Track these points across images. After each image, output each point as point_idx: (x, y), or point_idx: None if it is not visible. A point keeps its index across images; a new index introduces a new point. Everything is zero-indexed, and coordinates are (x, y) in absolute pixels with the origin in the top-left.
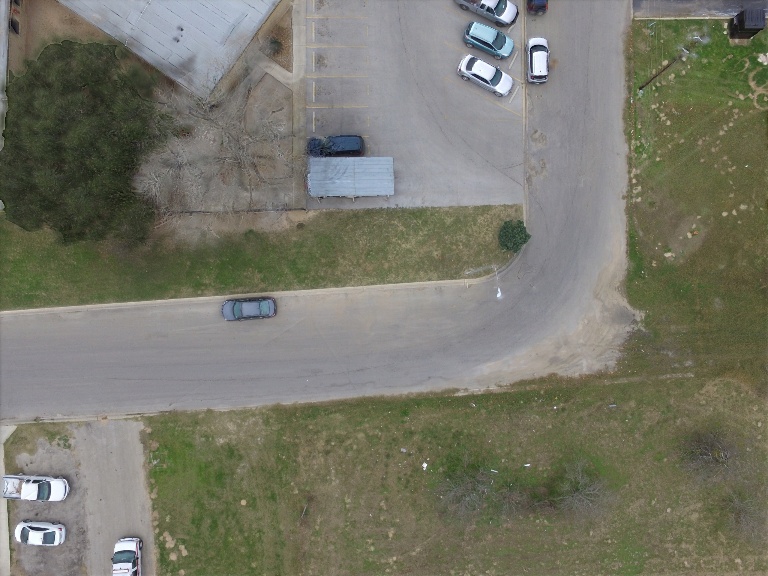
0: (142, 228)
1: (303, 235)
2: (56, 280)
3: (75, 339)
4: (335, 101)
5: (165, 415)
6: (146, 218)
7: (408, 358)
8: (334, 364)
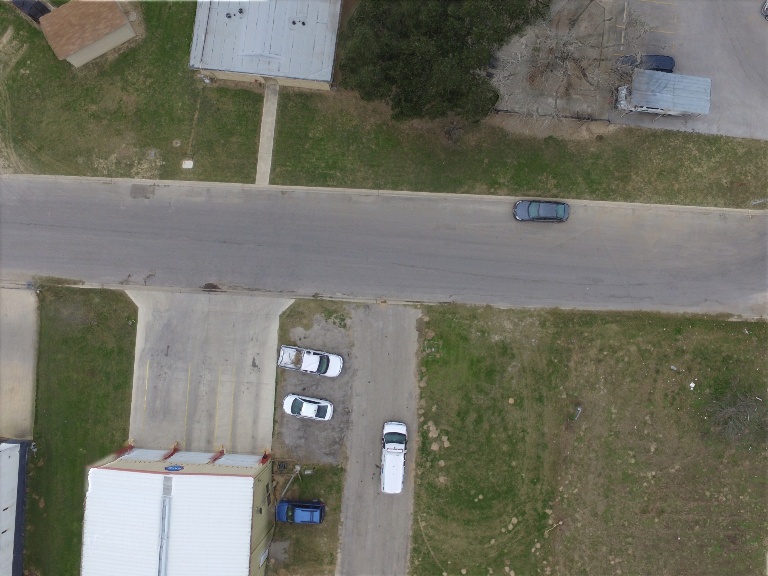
0: (483, 110)
1: (601, 147)
2: (352, 161)
3: (363, 221)
4: None
5: (444, 306)
6: (490, 100)
7: (687, 279)
8: (615, 276)
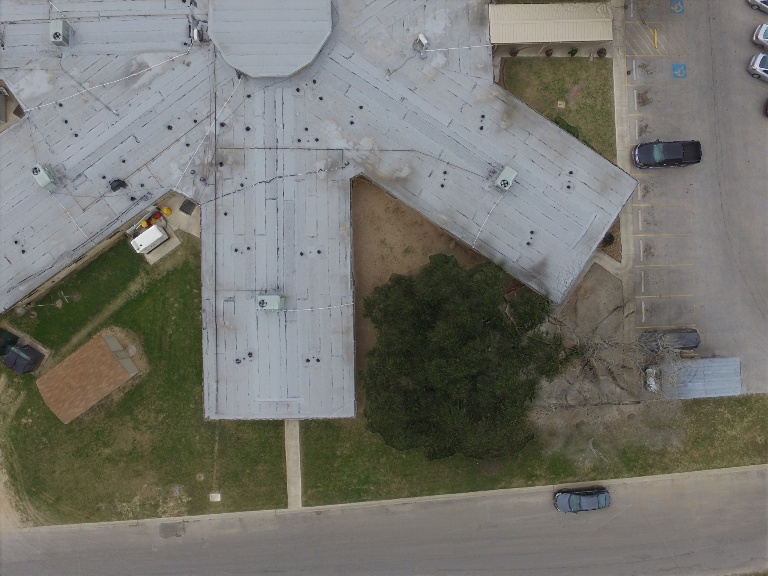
0: (519, 447)
1: (634, 425)
2: (384, 474)
3: (404, 532)
4: (663, 290)
5: None
6: (526, 439)
7: (732, 541)
8: (662, 549)
